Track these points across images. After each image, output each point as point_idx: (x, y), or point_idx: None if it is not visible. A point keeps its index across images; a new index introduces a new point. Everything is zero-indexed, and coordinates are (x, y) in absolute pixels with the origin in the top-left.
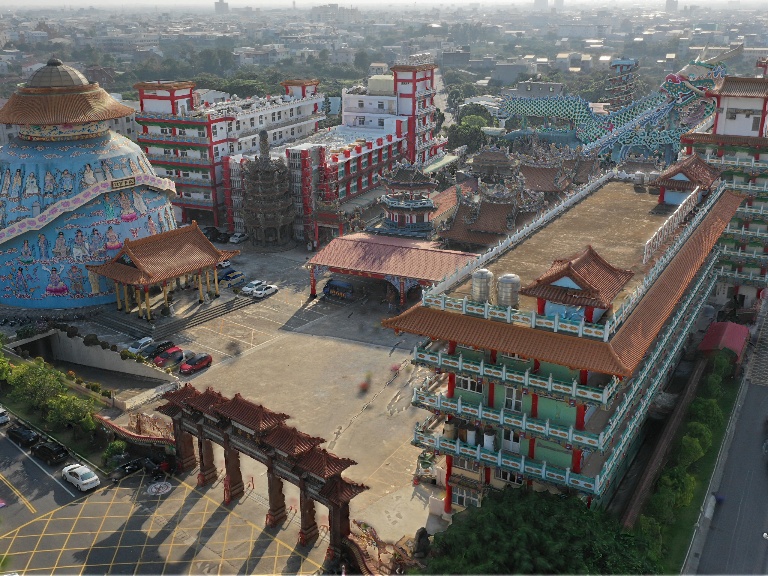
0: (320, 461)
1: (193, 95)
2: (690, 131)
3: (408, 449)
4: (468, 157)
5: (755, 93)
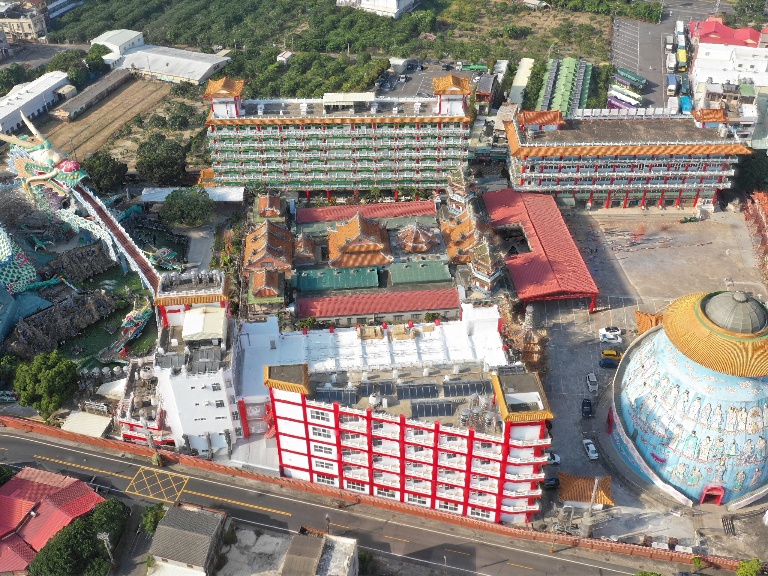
0: (765, 195)
1: None
2: (448, 120)
3: None
4: None
5: (465, 83)
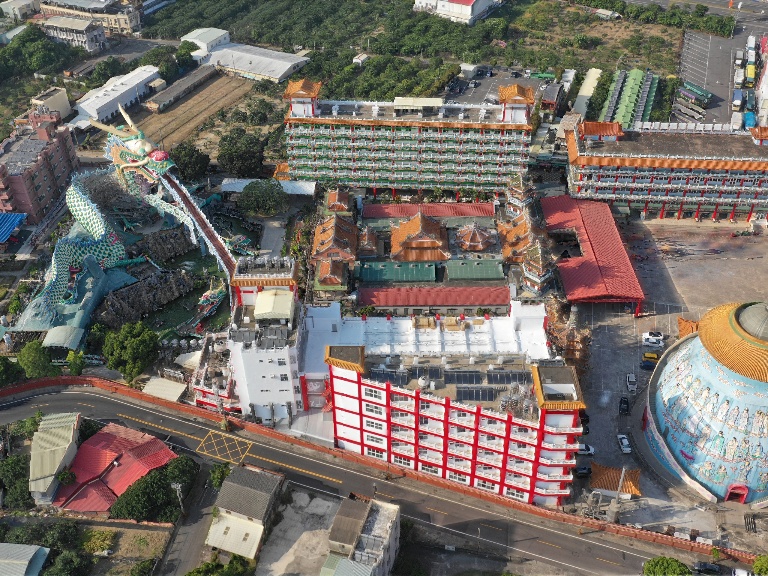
0: None
1: (520, 388)
2: (511, 127)
3: (741, 241)
4: (114, 370)
5: (529, 92)
